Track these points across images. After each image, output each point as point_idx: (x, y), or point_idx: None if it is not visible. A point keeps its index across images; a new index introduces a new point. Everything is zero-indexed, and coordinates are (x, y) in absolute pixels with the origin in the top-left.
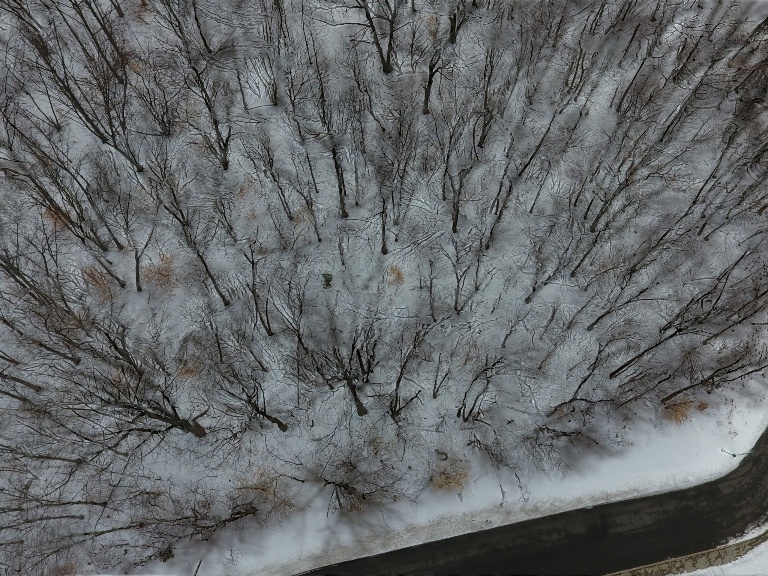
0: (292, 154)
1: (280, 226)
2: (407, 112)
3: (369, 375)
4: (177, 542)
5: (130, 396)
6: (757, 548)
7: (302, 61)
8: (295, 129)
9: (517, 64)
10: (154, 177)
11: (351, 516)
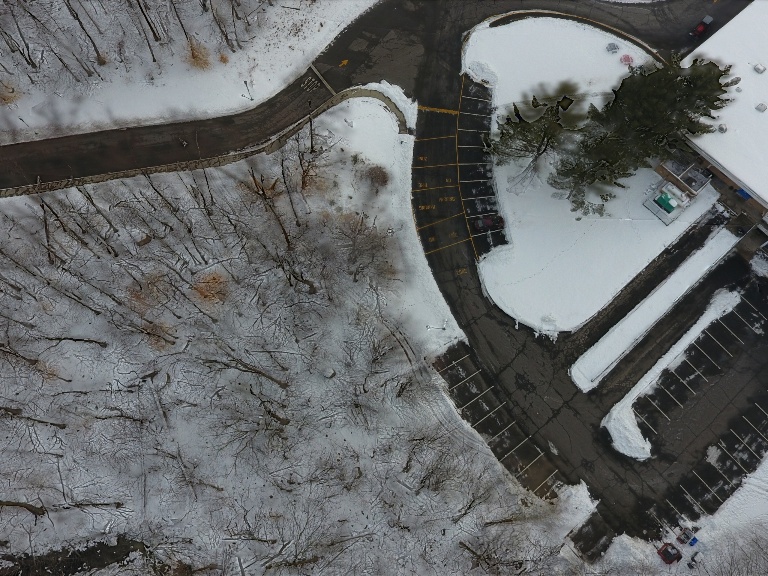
0: None
1: None
2: None
3: None
4: None
5: None
6: (250, 157)
7: None
8: None
9: None
10: None
11: None
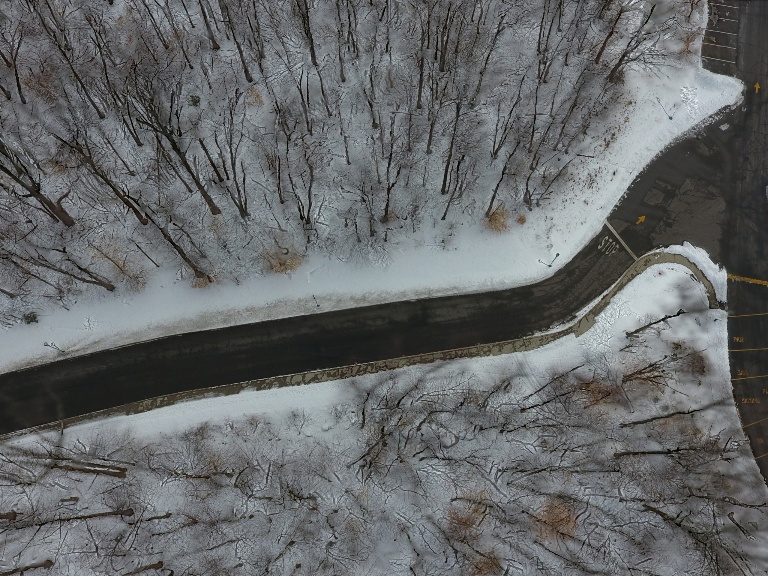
0: None
1: (154, 52)
2: None
3: (225, 182)
4: (42, 310)
5: (8, 189)
6: (558, 340)
7: None
8: None
9: None
10: None
11: (198, 296)
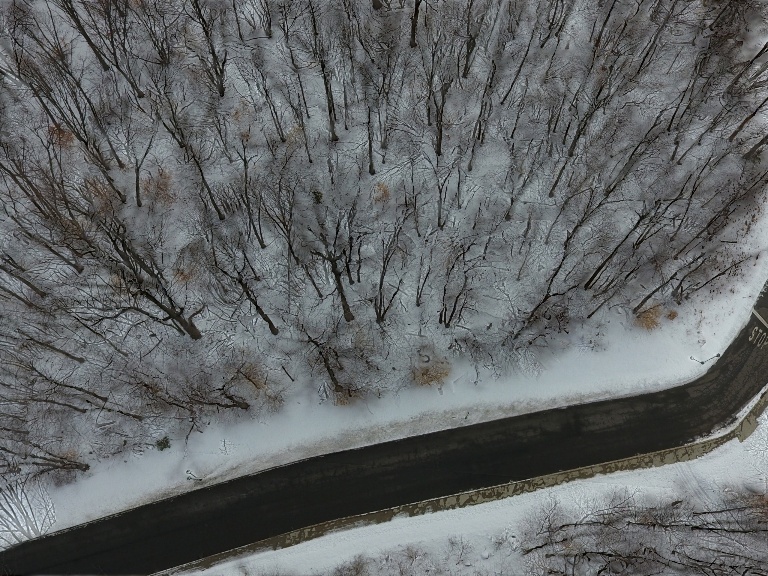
0: (284, 75)
1: (273, 147)
2: (395, 42)
3: (356, 284)
4: (174, 434)
5: (130, 301)
6: (722, 446)
7: None
8: (288, 56)
9: None
10: None
11: (338, 412)
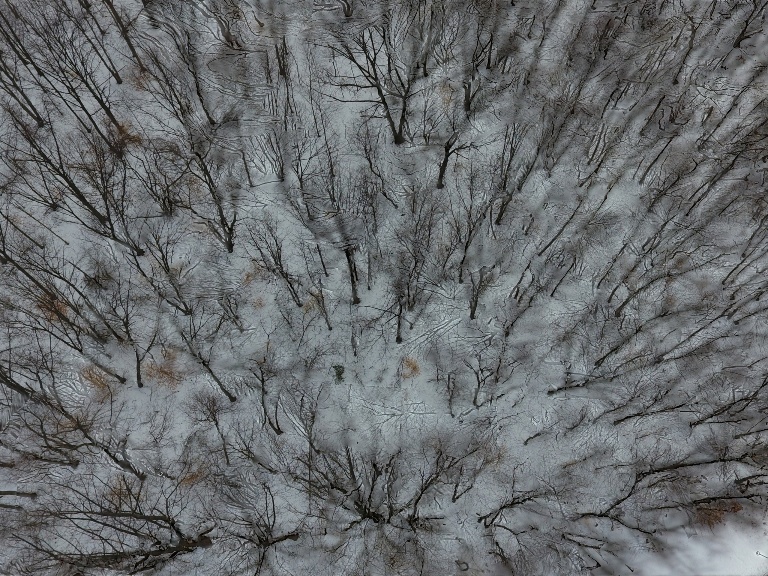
0: (301, 244)
1: (289, 315)
2: (421, 191)
3: None
4: None
5: (131, 504)
6: None
7: (310, 134)
8: (304, 212)
9: (538, 144)
10: (155, 263)
11: None
